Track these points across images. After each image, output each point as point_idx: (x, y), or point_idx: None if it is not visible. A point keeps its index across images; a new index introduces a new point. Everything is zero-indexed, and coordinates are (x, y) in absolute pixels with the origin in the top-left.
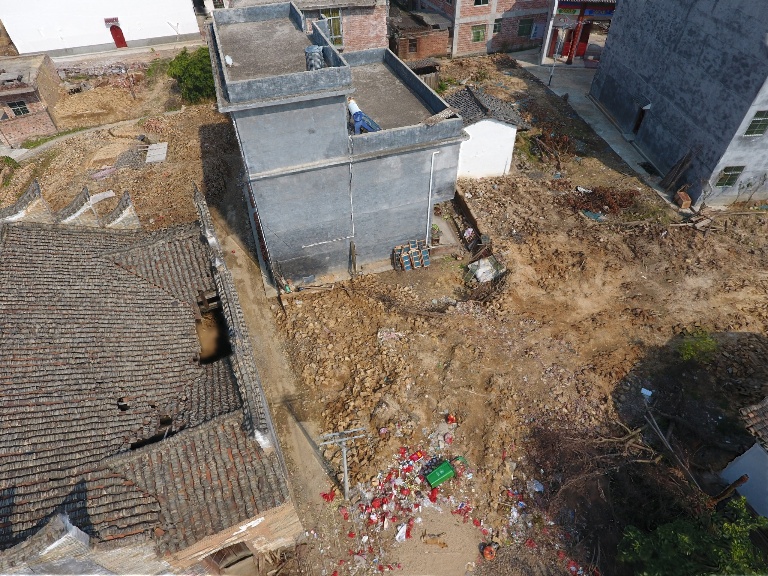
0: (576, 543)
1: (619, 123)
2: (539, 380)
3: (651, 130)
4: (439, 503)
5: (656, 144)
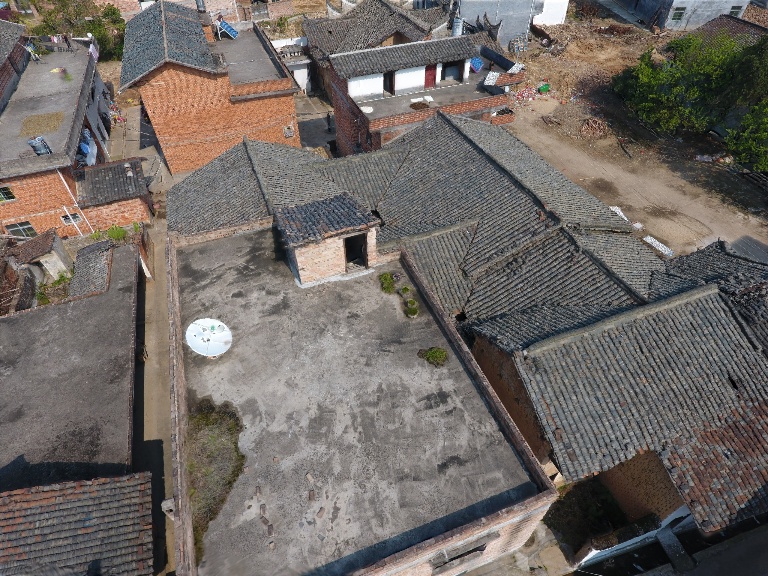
0: (595, 102)
1: (627, 7)
2: (581, 72)
3: (643, 3)
4: (543, 95)
5: (645, 10)
